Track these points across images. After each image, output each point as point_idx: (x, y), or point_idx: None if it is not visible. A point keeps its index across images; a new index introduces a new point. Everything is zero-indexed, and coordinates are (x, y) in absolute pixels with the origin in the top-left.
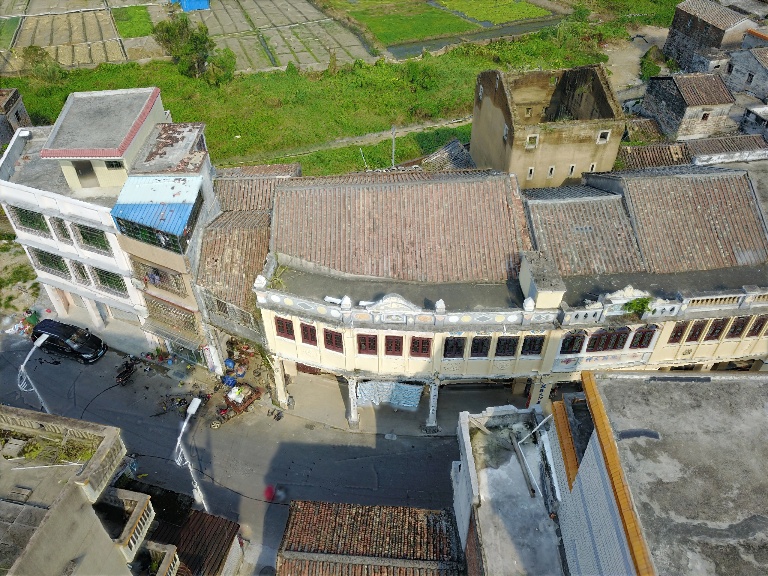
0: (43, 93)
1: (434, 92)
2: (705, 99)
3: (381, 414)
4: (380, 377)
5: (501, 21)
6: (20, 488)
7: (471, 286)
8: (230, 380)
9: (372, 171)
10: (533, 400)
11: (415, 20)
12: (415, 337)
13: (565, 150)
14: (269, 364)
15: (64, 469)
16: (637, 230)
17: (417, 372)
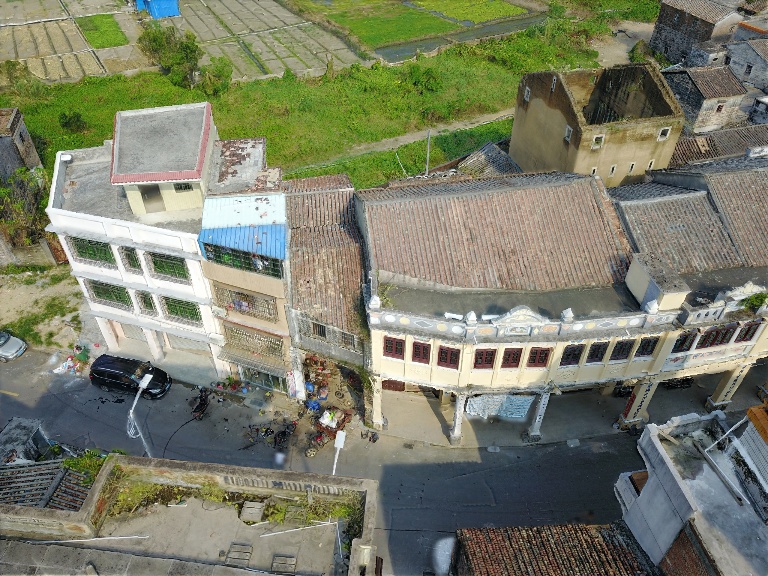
0: (29, 111)
1: (441, 94)
2: (720, 91)
3: (478, 427)
4: (494, 390)
5: (481, 20)
6: (283, 557)
7: (579, 291)
8: (314, 404)
9: (413, 178)
10: (637, 400)
11: (396, 21)
12: (534, 348)
13: (627, 149)
14: (370, 386)
15: (318, 530)
16: (728, 225)
17: (530, 382)
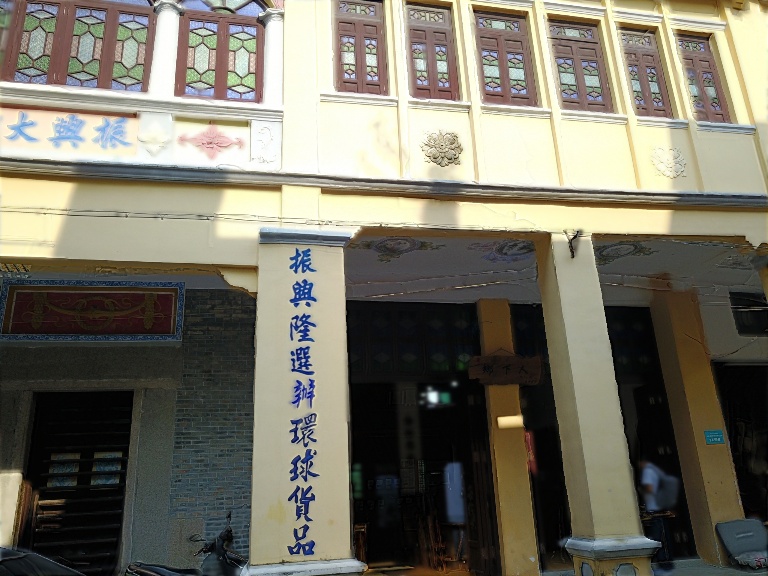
0: None
1: None
2: None
3: None
4: None
5: None
6: None
7: None
8: None
9: None
10: None
11: None
12: None
13: None
14: None
15: None
16: None
17: None
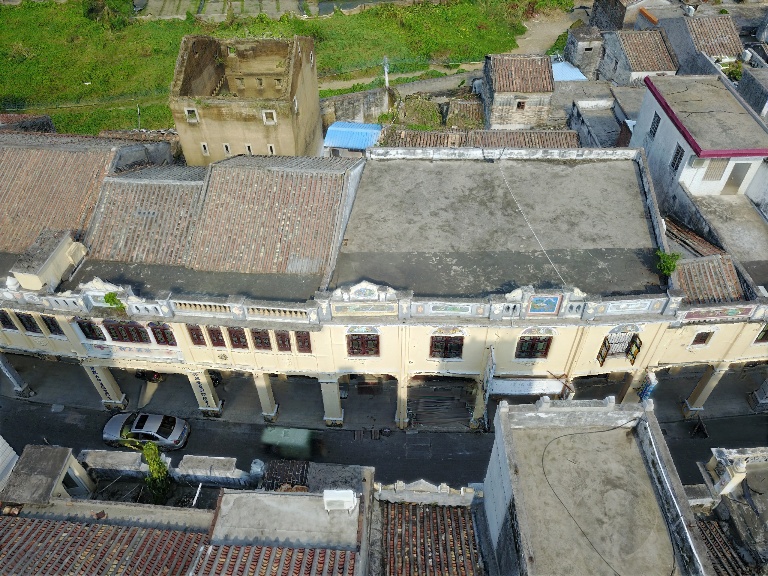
0: None
1: None
2: (518, 85)
3: None
4: None
5: None
6: None
7: (17, 258)
8: None
9: (136, 131)
10: (94, 381)
11: None
12: None
13: (232, 128)
14: None
15: None
16: (197, 221)
17: None
